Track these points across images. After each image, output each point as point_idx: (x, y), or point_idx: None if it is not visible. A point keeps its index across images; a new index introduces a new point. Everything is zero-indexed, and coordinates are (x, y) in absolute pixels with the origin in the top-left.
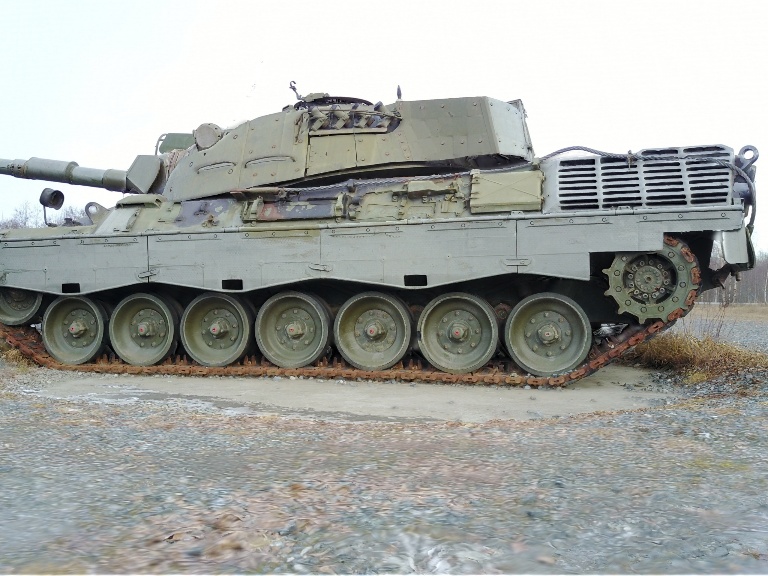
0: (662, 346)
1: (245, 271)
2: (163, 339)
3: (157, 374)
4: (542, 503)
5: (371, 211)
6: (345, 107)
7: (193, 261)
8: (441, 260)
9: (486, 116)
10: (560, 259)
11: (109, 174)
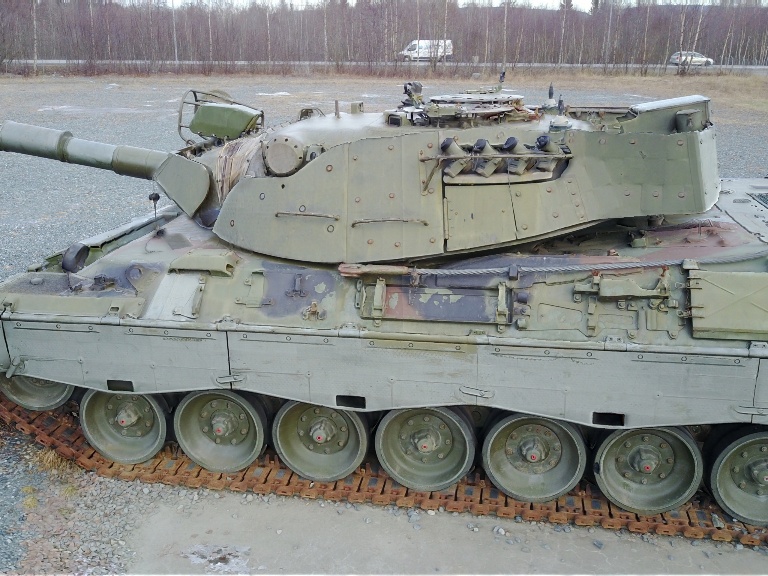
0: None
1: (369, 388)
2: (246, 436)
3: (248, 493)
4: None
5: (545, 316)
6: (490, 134)
7: (294, 369)
8: (647, 398)
9: (694, 161)
10: None
11: (121, 156)
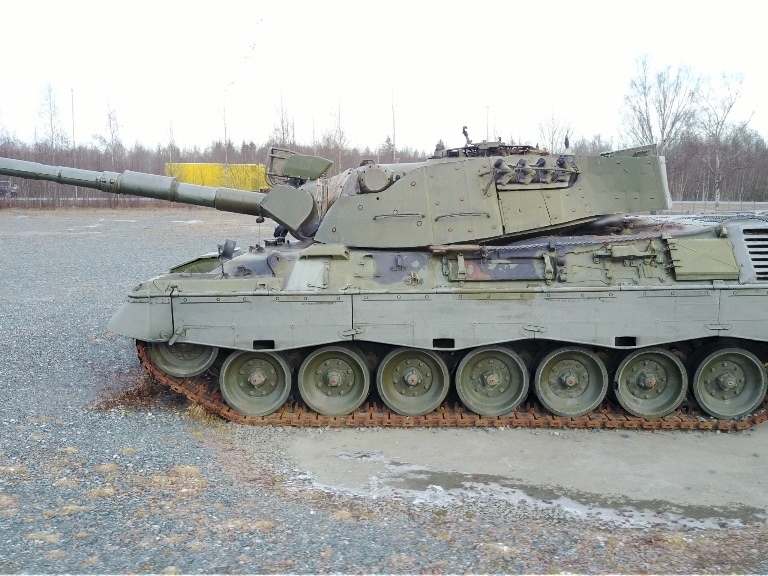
0: None
1: (458, 331)
2: (351, 388)
3: (361, 427)
4: None
5: (577, 273)
6: (524, 158)
7: (402, 321)
8: (651, 324)
9: (658, 174)
10: (757, 325)
11: (223, 194)
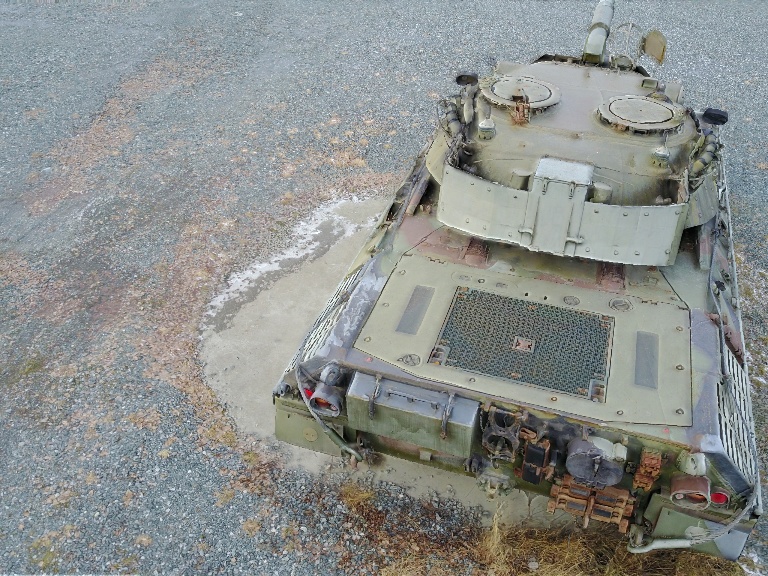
0: (564, 530)
1: None
2: None
3: None
4: (2, 316)
5: None
6: None
7: None
8: None
9: None
10: None
11: None
